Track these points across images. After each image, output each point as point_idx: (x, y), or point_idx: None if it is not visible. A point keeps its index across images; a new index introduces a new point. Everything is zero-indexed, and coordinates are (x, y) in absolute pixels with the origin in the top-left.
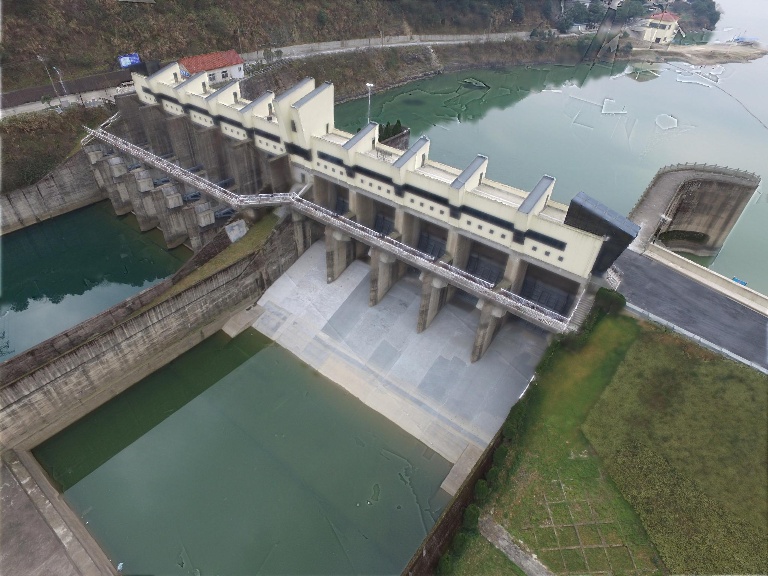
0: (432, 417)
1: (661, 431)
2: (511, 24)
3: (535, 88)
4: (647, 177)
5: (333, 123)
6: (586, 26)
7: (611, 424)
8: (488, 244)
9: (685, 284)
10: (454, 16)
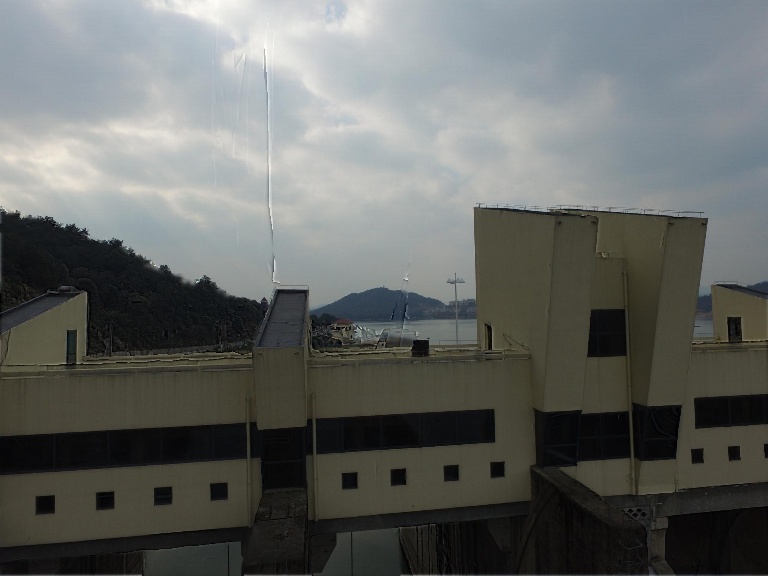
0: None
1: None
2: (232, 335)
3: None
4: None
5: None
6: None
7: None
8: None
9: None
10: (177, 327)
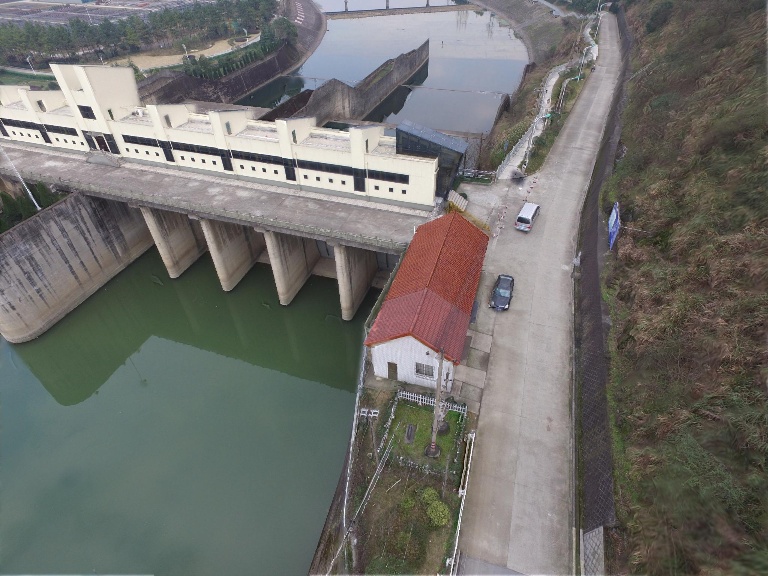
0: None
1: None
2: None
3: None
4: None
5: (74, 111)
6: None
7: None
8: None
9: None
10: None
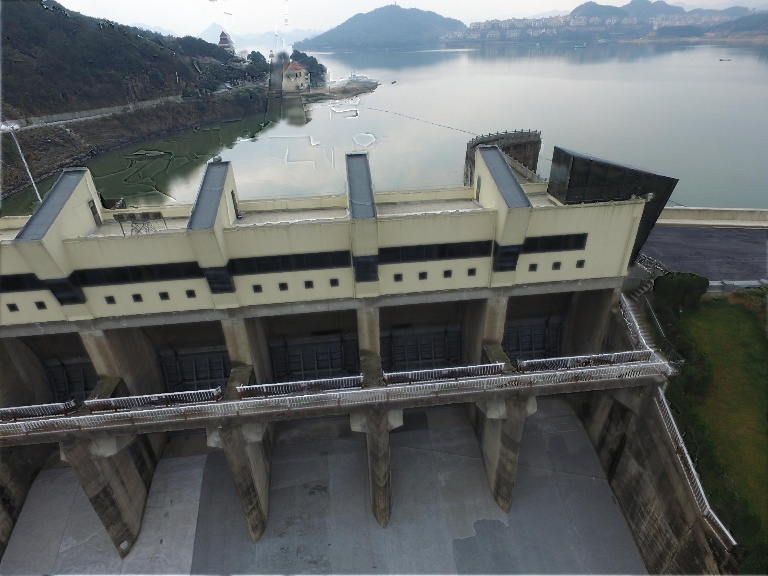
0: None
1: None
2: (152, 91)
3: (213, 150)
4: None
5: None
6: (230, 84)
7: None
8: (443, 299)
9: (671, 233)
10: (77, 88)
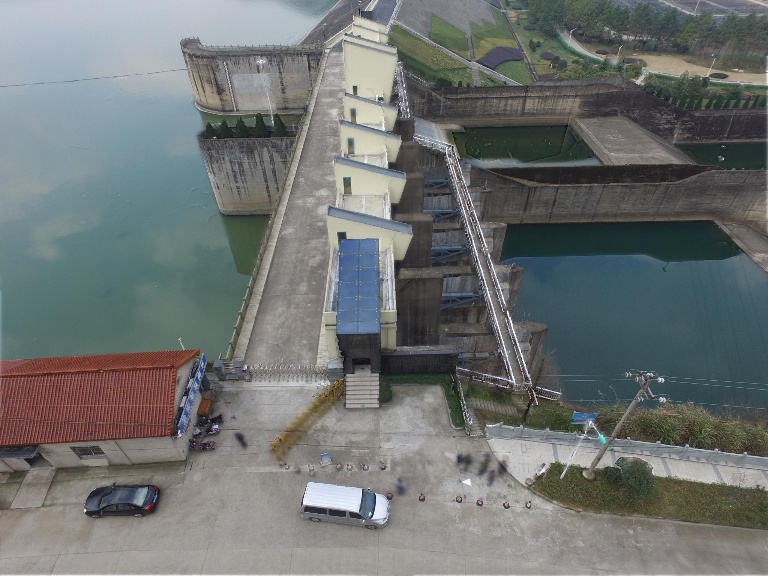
0: (442, 138)
1: None
2: None
3: None
4: (86, 122)
5: None
6: None
7: None
8: None
9: None
10: None
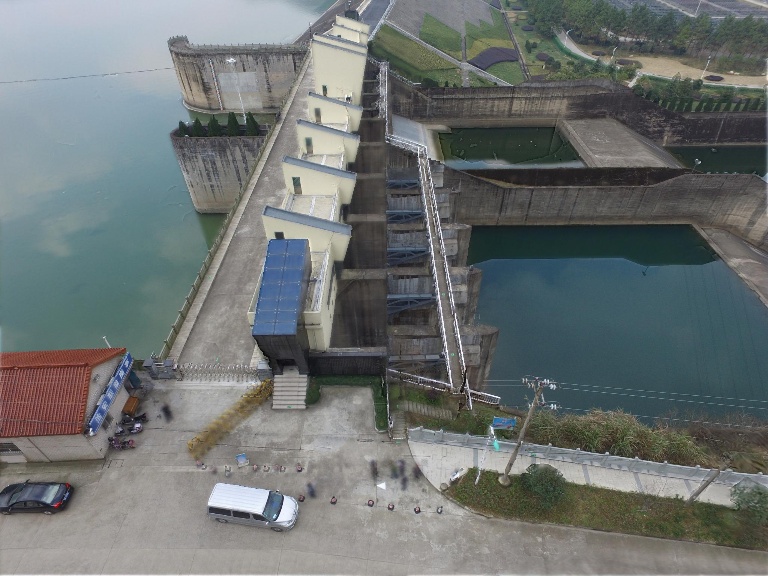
0: (427, 138)
1: (410, 56)
2: None
3: None
4: None
5: None
6: None
7: (416, 64)
8: None
9: None
10: None
